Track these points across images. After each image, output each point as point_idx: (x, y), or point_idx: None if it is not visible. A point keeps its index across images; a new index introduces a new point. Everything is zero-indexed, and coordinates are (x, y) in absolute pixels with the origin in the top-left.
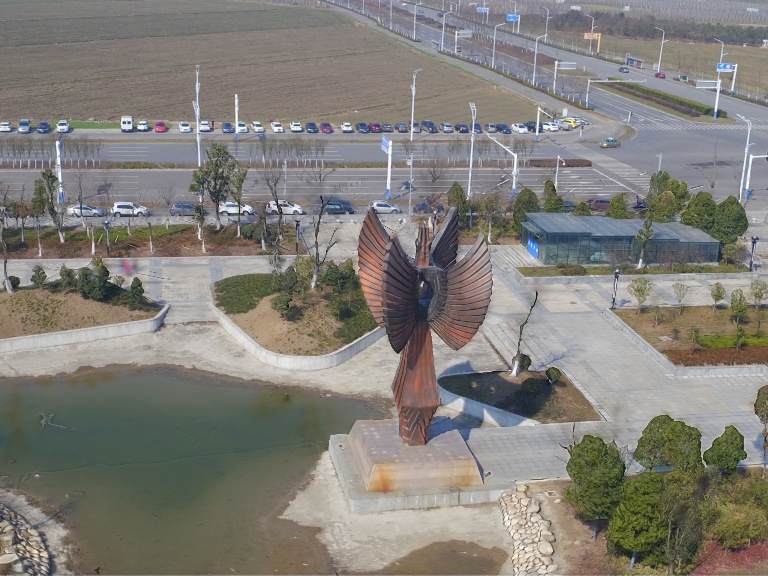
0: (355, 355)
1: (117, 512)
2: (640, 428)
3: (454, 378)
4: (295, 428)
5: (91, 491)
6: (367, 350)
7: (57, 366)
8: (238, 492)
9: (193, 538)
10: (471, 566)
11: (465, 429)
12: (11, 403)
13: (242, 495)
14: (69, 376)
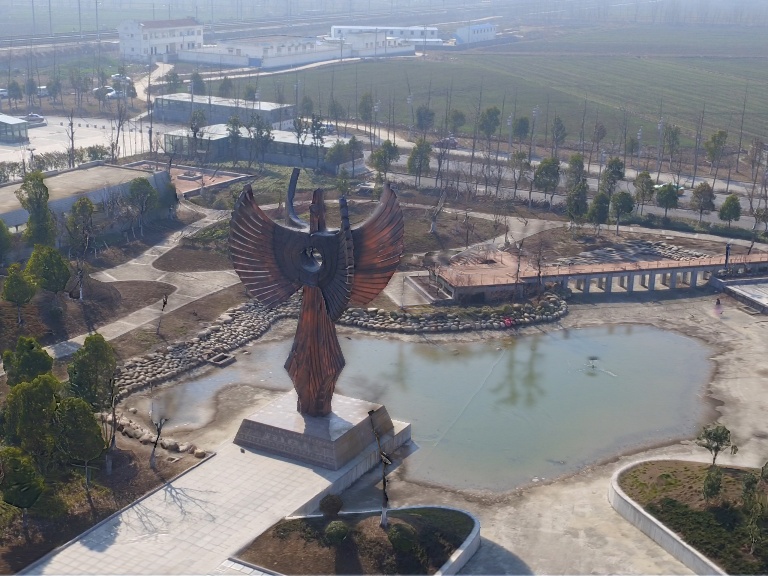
0: (639, 529)
1: (413, 356)
2: (183, 569)
3: (461, 524)
4: (481, 446)
5: (455, 357)
6: (652, 543)
7: (731, 393)
8: (389, 391)
9: (347, 365)
10: (169, 419)
11: (336, 479)
12: (652, 366)
13: (382, 391)
14: (701, 393)
